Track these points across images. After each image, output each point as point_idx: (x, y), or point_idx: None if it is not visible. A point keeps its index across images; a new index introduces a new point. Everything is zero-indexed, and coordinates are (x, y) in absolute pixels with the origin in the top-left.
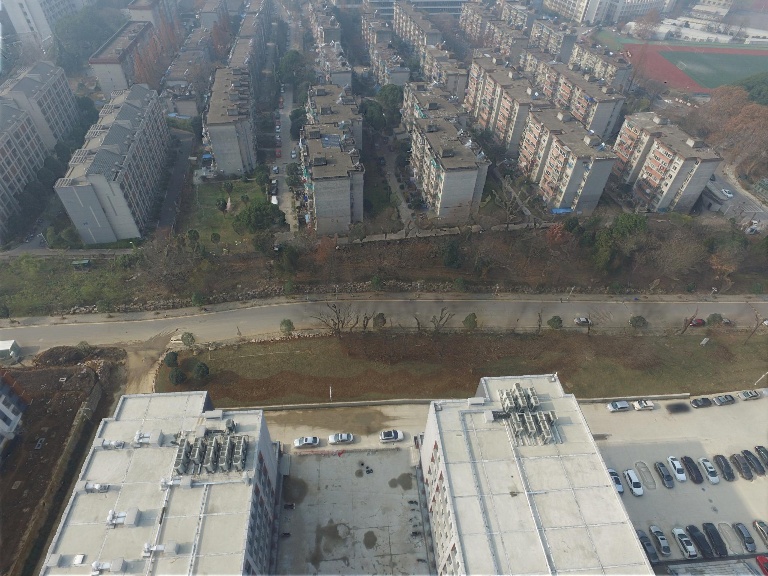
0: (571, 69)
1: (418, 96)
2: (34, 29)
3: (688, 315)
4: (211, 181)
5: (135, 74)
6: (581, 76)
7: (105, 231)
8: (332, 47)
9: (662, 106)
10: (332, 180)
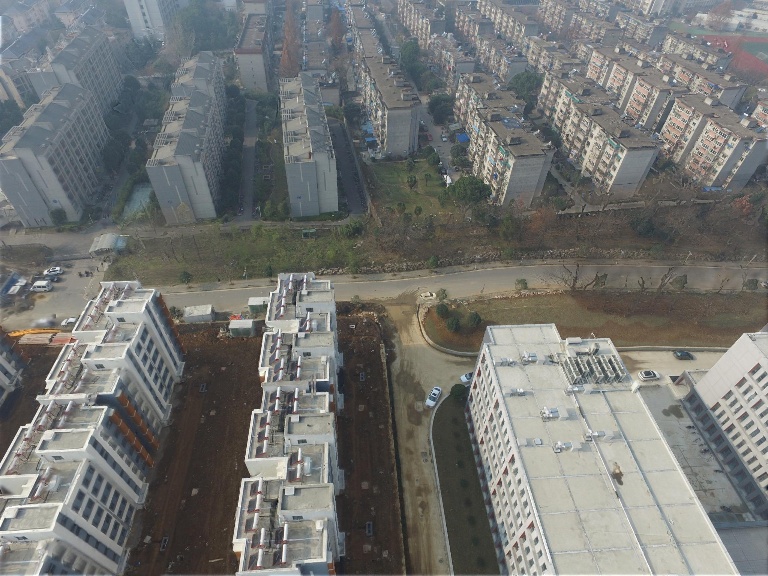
0: (685, 58)
1: (565, 83)
2: (148, 22)
3: None
4: (380, 162)
5: (280, 63)
6: (697, 65)
7: (312, 205)
8: (445, 38)
9: (757, 94)
10: (531, 157)
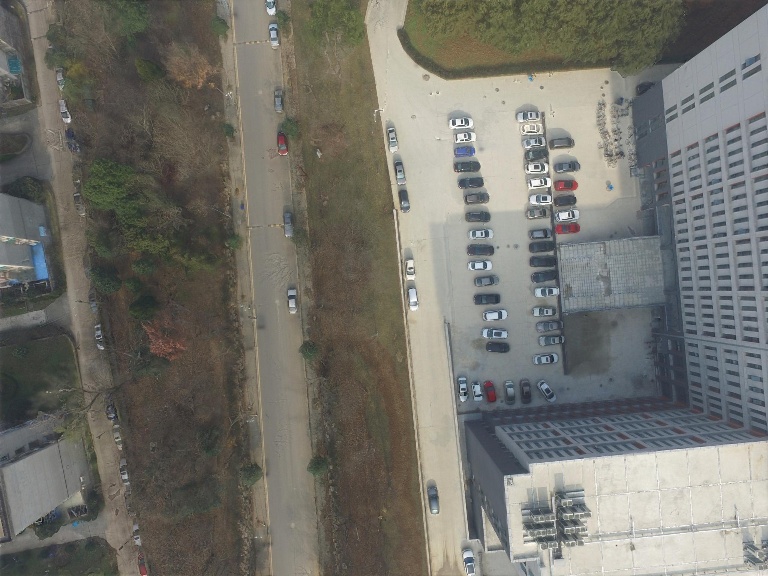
0: None
1: None
2: None
3: (267, 146)
4: None
5: None
6: None
7: None
8: None
9: None
10: None
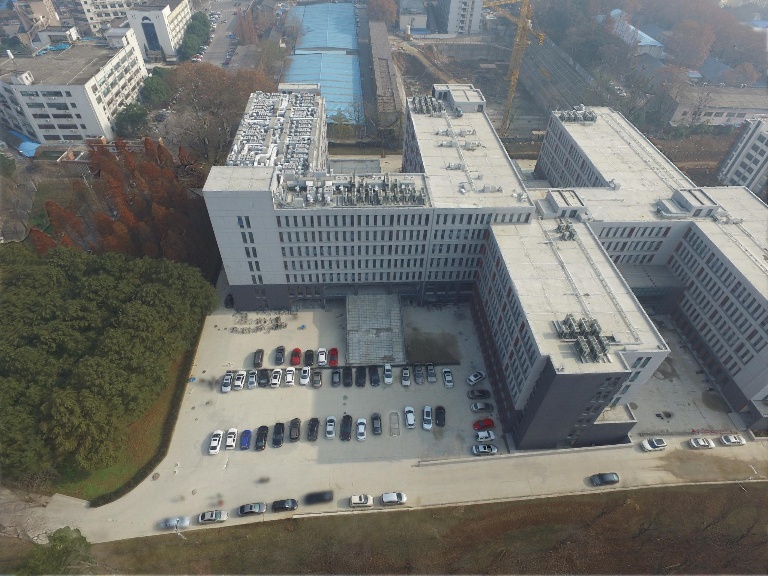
0: None
1: None
2: None
3: None
4: None
5: None
6: None
7: None
8: None
9: None
10: None
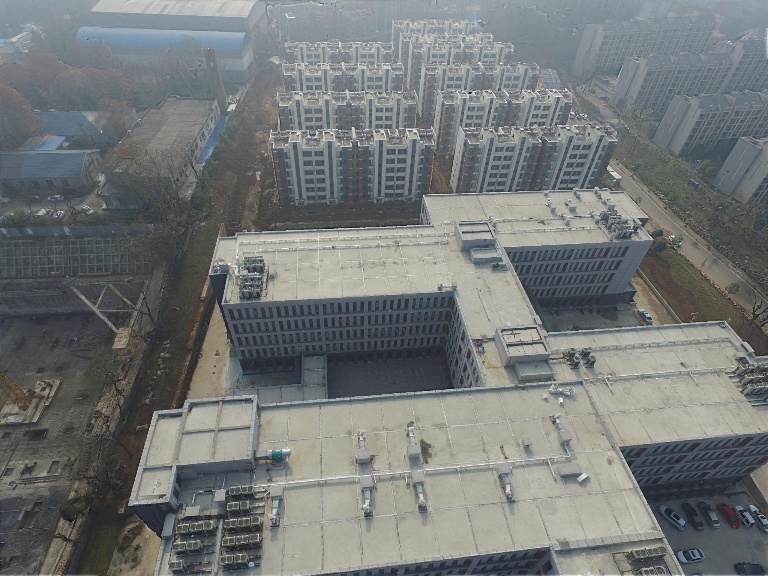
0: None
1: None
2: None
3: None
4: None
5: None
6: None
7: (731, 184)
8: None
9: None
10: None
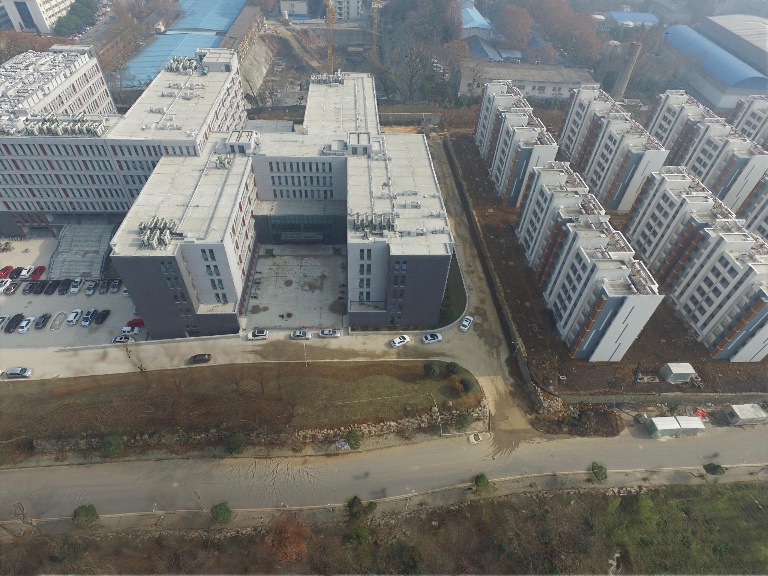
0: None
1: None
2: None
3: None
4: None
5: None
6: None
7: None
8: None
9: None
10: None
